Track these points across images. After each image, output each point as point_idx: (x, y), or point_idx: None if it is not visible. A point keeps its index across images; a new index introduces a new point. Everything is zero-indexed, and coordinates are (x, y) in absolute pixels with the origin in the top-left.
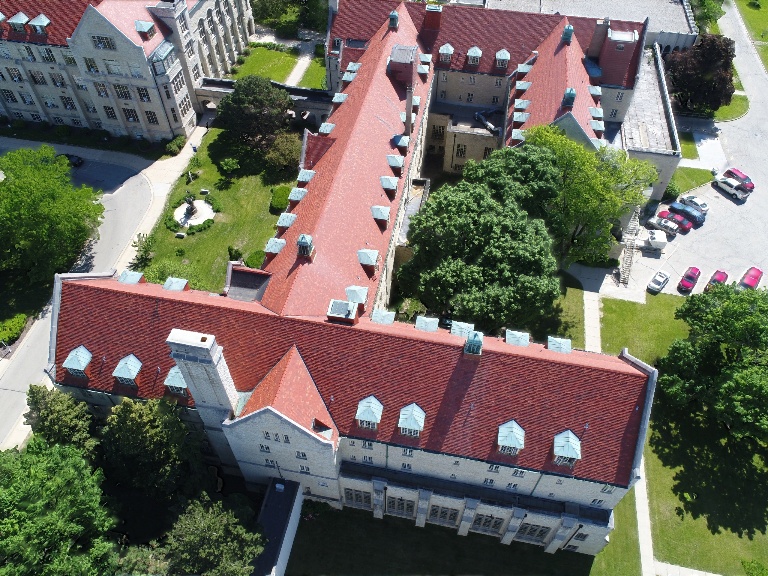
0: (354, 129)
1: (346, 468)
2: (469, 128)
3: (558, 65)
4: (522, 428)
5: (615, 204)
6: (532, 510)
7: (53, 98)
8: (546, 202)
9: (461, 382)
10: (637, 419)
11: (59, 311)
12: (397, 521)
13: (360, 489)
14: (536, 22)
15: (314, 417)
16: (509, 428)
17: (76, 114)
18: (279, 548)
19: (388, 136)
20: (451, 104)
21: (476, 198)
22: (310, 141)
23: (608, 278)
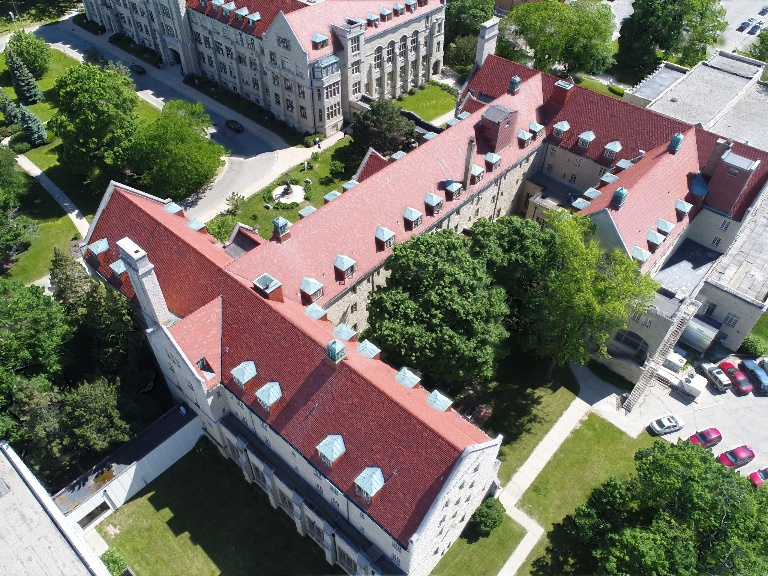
0: (402, 159)
1: (230, 420)
2: (555, 205)
3: (646, 168)
4: (345, 446)
5: (593, 307)
6: (339, 532)
7: (248, 77)
8: (551, 287)
9: (316, 381)
10: (438, 488)
11: (105, 208)
12: (260, 492)
13: (234, 443)
14: (661, 124)
15: (204, 356)
16: (333, 439)
17: (259, 94)
18: (149, 451)
19: (440, 177)
20: (554, 179)
21: (449, 246)
22: (371, 159)
23: (613, 397)
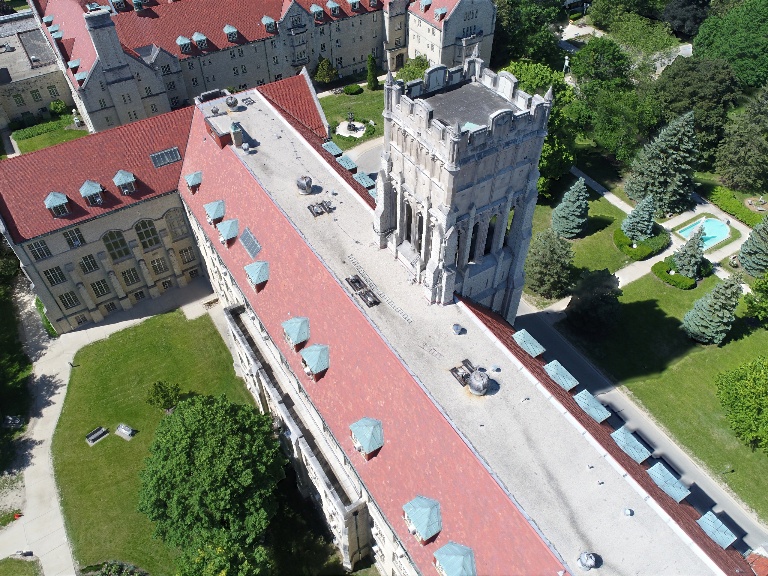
0: None
1: None
2: None
3: None
4: None
5: None
6: None
7: None
8: None
9: None
10: None
11: None
12: None
13: None
14: None
15: None
16: None
17: None
18: None
19: None
20: None
21: None
22: None
23: None
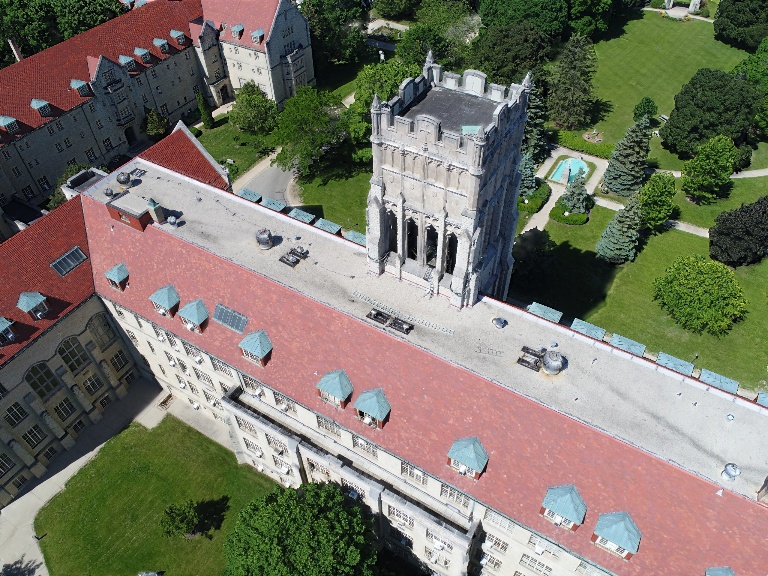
0: (76, 36)
1: None
2: None
3: None
4: None
5: None
6: None
7: None
8: None
9: None
10: None
11: None
12: None
13: None
14: None
15: None
16: None
17: None
18: None
19: None
20: None
21: None
22: None
23: None
